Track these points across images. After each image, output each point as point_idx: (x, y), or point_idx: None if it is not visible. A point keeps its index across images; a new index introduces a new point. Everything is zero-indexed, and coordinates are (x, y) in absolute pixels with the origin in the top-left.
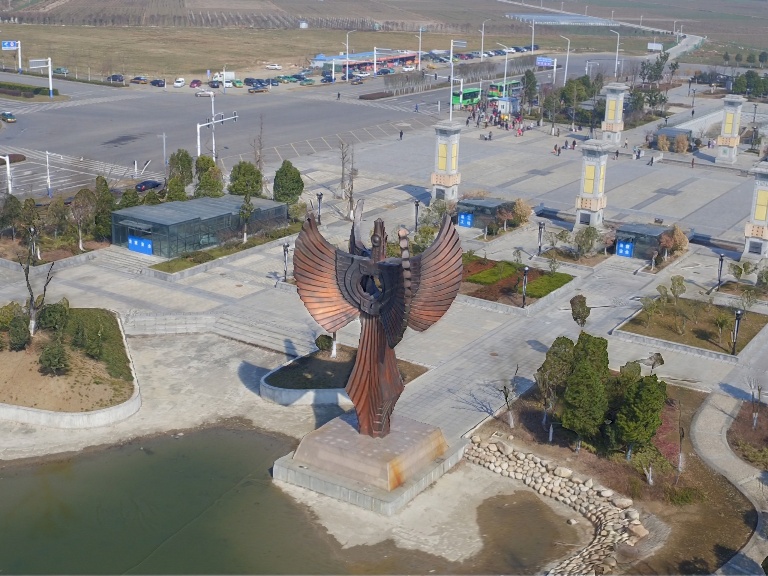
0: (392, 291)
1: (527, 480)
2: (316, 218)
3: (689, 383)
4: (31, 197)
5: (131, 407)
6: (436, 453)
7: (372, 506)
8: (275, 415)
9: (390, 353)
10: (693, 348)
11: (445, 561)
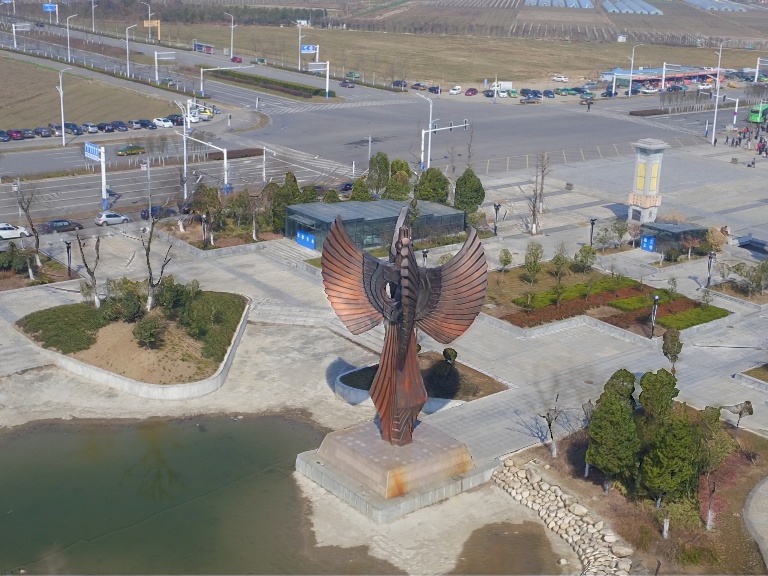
0: None
1: (541, 512)
2: (492, 229)
3: None
4: (248, 188)
5: (207, 386)
6: (456, 470)
7: (366, 511)
8: (337, 412)
9: (413, 362)
10: None
11: (405, 575)
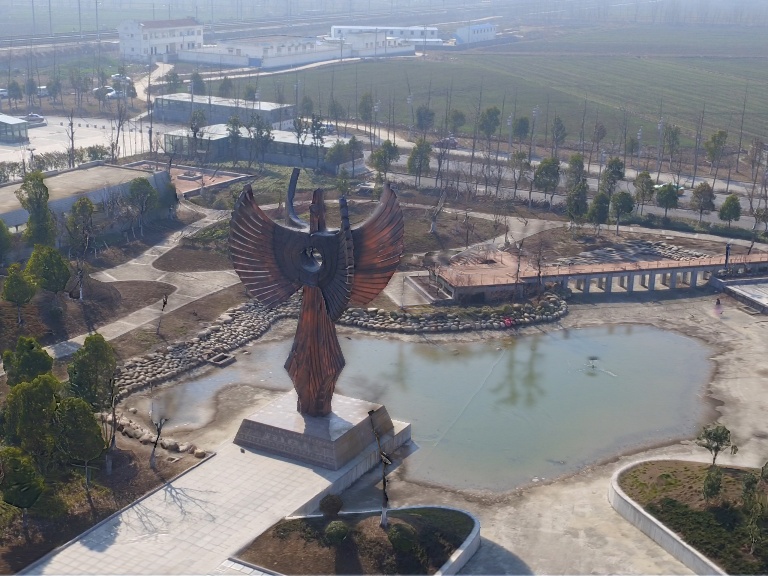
0: None
1: None
2: None
3: None
4: None
5: None
6: None
7: None
8: None
9: None
10: None
11: (253, 385)
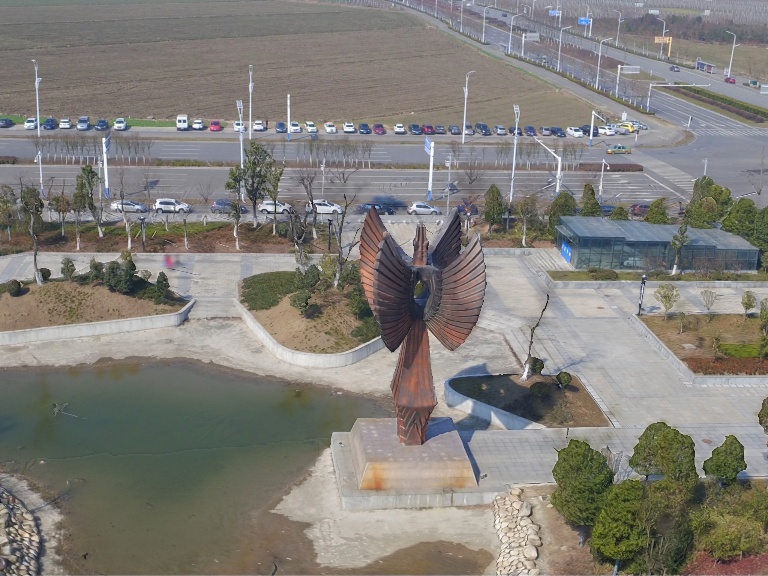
0: None
1: (502, 545)
2: None
3: None
4: None
5: (333, 360)
6: (452, 482)
7: None
8: None
9: (424, 363)
10: None
11: (312, 558)
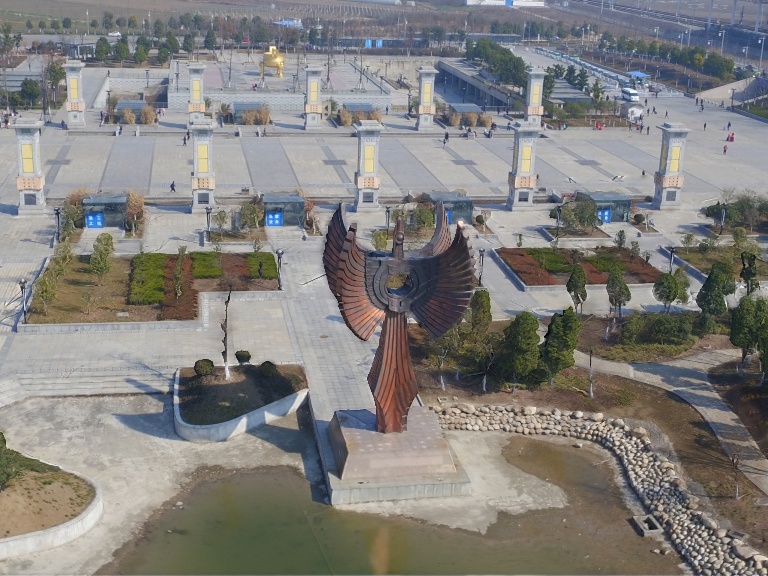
0: (429, 284)
1: (507, 427)
2: None
3: None
4: None
5: None
6: None
7: (452, 492)
8: (231, 453)
9: None
10: None
11: (559, 509)
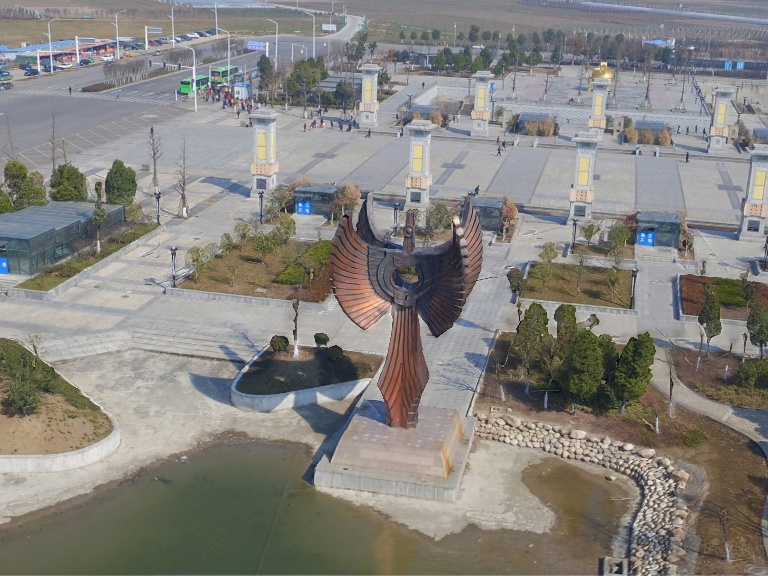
0: (433, 280)
1: (547, 447)
2: (155, 219)
3: (614, 339)
4: None
5: (117, 437)
6: (460, 435)
7: (434, 495)
8: (264, 423)
9: (419, 343)
10: (595, 307)
11: (535, 534)
